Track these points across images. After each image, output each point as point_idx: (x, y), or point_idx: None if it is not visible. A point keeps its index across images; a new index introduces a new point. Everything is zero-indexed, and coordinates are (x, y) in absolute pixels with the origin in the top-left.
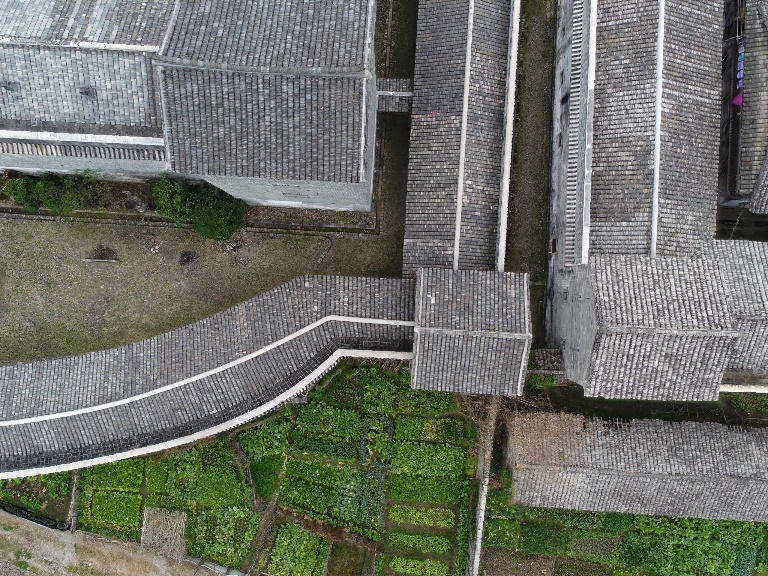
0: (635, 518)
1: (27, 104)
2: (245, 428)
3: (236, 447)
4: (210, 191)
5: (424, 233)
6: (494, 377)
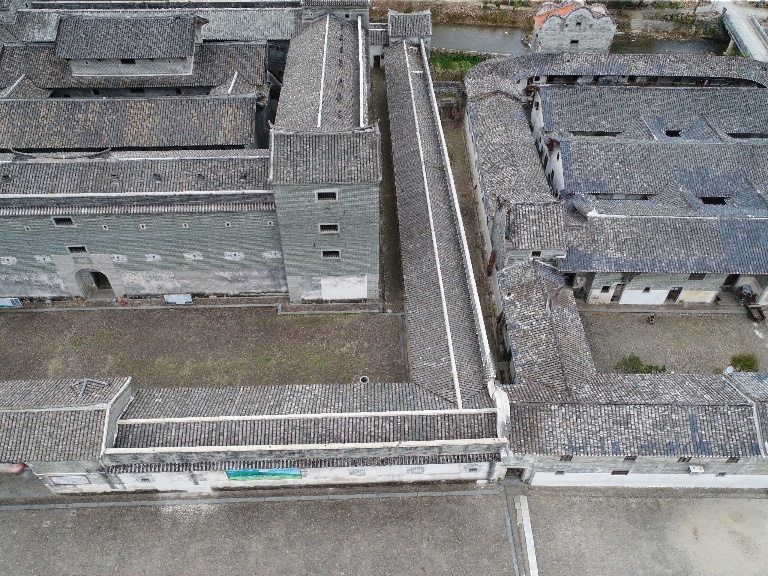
0: None
1: None
2: None
3: None
4: None
5: None
6: None
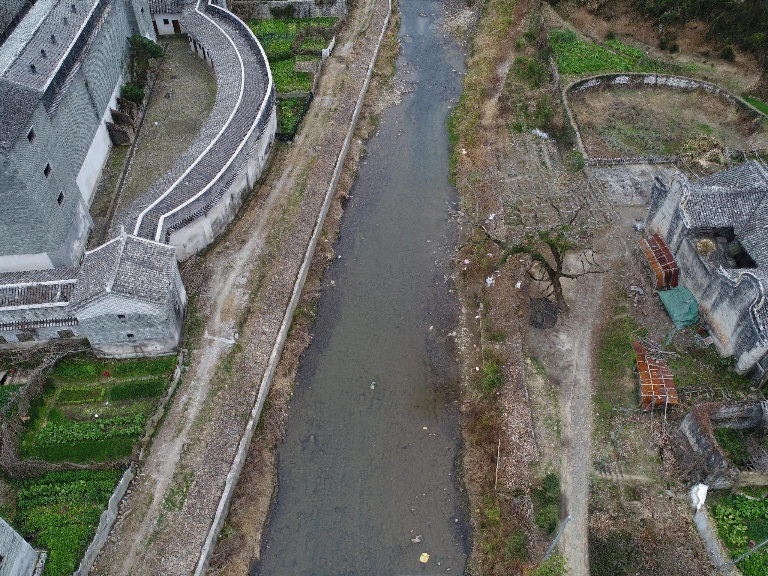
0: None
1: (88, 2)
2: None
3: None
4: None
5: (165, 6)
6: None
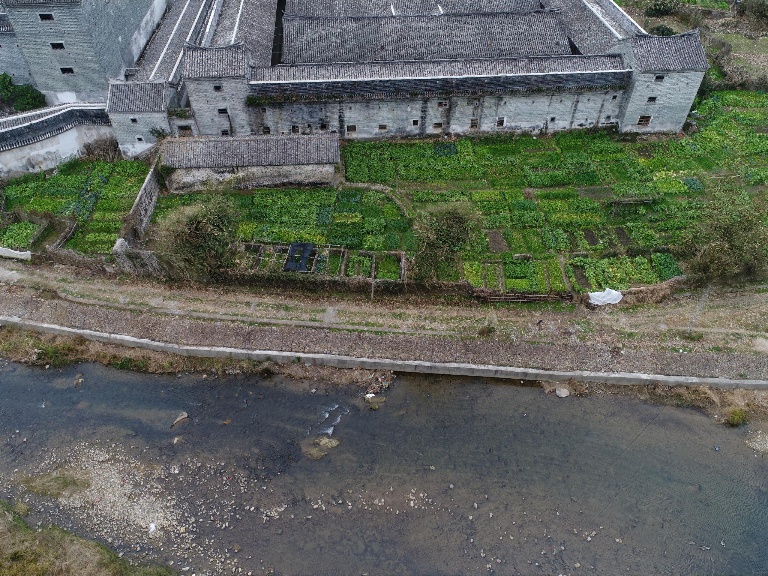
0: (254, 199)
1: None
2: (9, 174)
3: (0, 189)
4: (27, 85)
5: None
6: (150, 103)
